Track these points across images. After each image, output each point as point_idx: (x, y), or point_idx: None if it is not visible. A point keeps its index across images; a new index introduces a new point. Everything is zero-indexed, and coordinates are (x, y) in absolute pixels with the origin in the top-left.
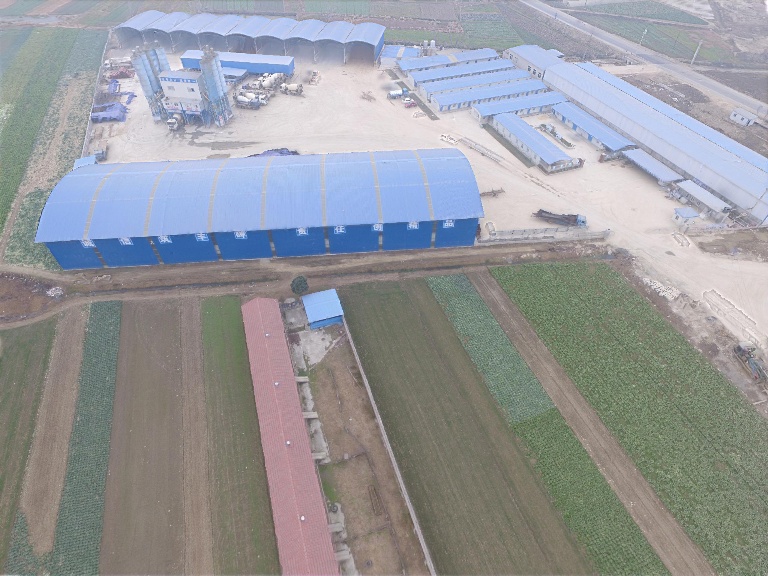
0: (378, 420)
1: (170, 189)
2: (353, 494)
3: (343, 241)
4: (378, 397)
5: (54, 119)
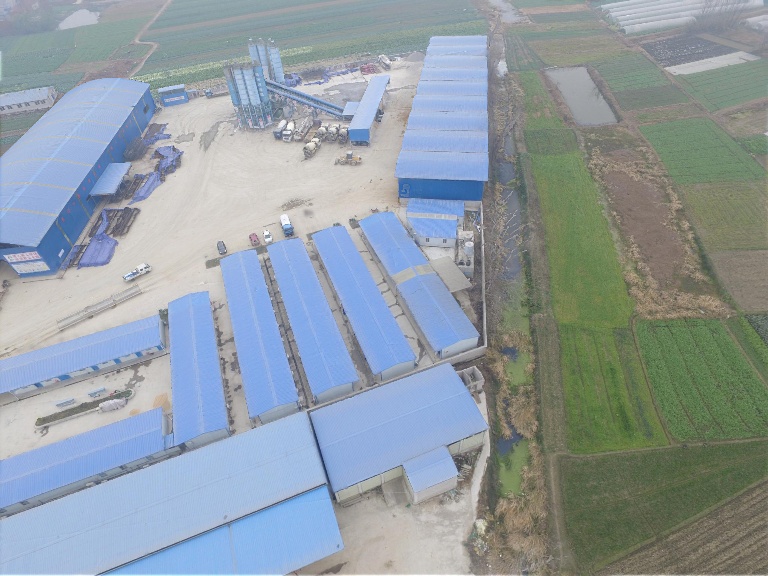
0: None
1: None
2: None
3: None
4: None
5: None
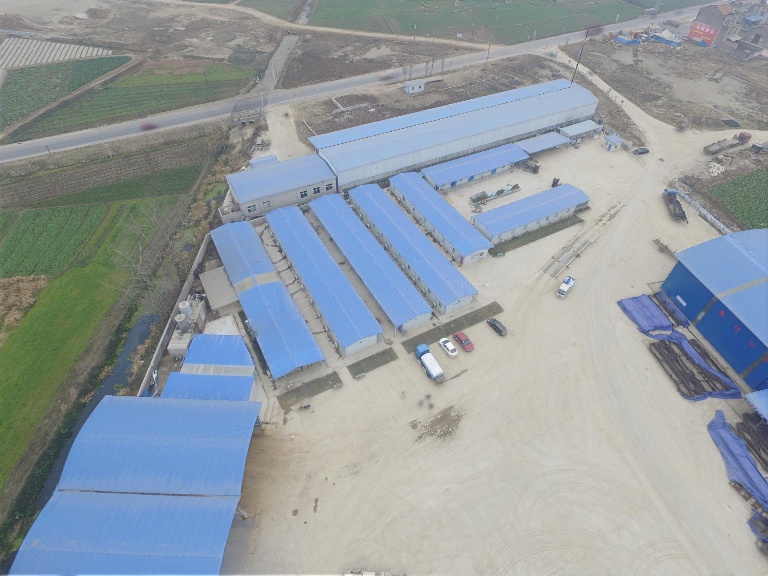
0: None
1: None
2: None
3: None
4: None
5: None
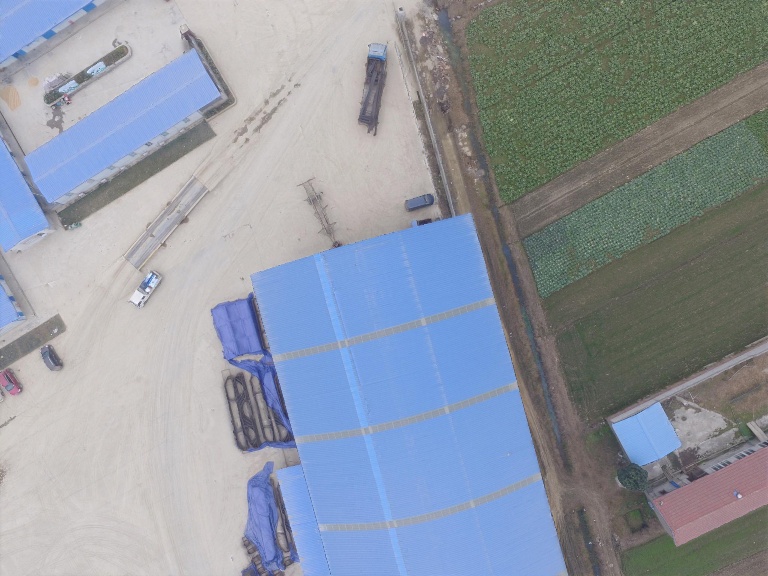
0: None
1: None
2: None
3: None
4: (761, 333)
5: None
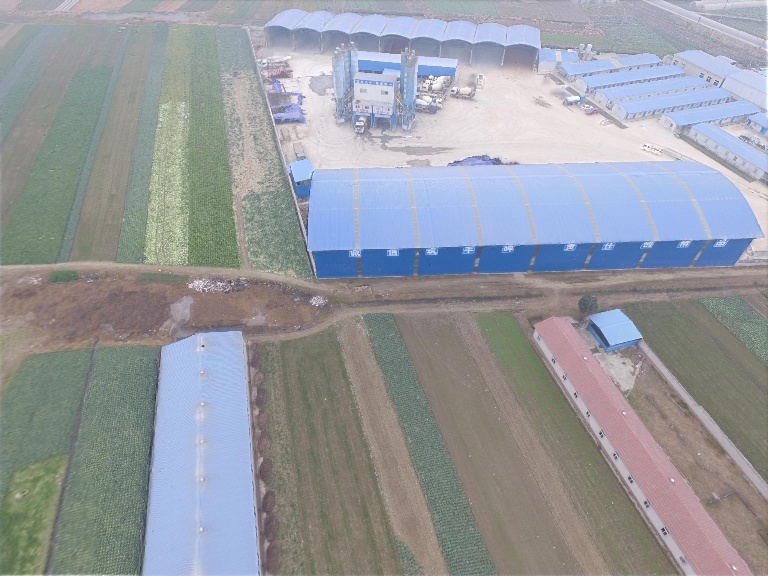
0: (736, 457)
1: (429, 198)
2: (744, 539)
3: (605, 257)
4: None
5: (235, 119)
